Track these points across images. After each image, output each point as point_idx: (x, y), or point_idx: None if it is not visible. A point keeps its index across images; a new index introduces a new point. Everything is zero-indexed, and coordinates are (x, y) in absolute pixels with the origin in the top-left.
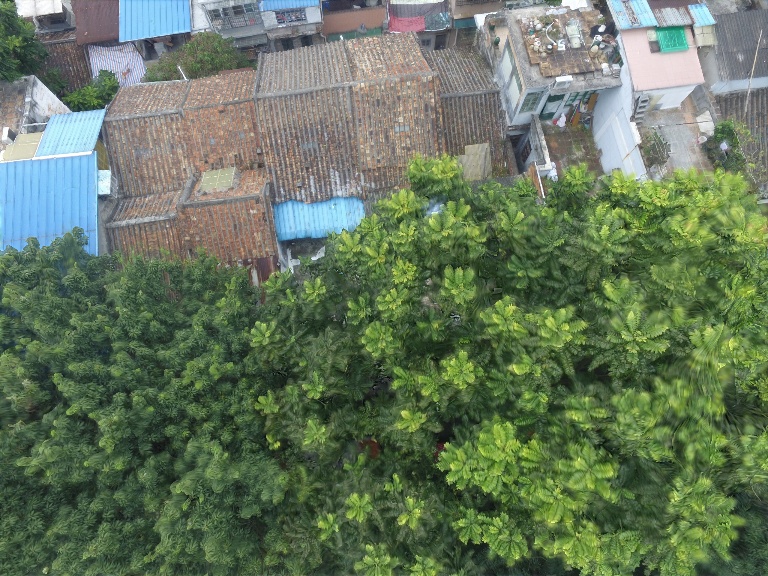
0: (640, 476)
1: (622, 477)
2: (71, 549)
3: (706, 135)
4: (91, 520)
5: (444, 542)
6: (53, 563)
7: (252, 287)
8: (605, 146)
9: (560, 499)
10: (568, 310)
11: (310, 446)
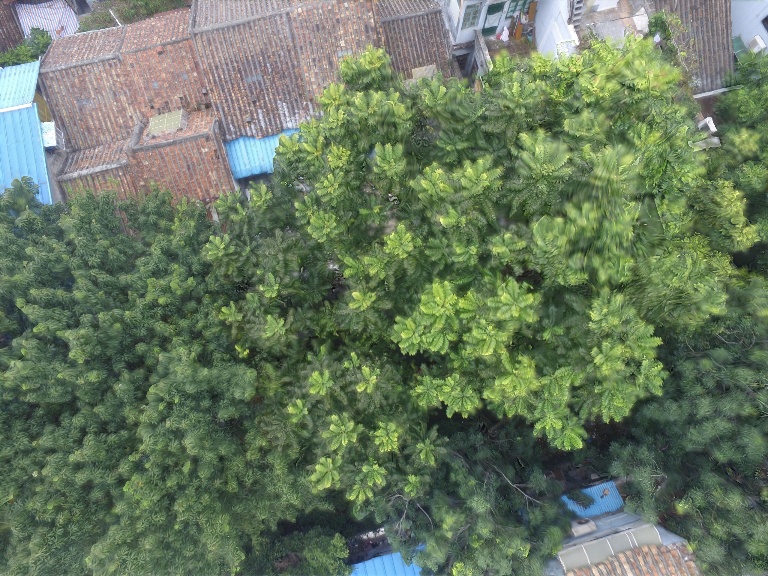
0: (566, 313)
1: (551, 317)
2: (58, 458)
3: (642, 33)
4: (75, 434)
5: (410, 419)
6: (42, 469)
7: (211, 221)
8: (548, 55)
9: (492, 335)
10: (485, 161)
11: (273, 340)
